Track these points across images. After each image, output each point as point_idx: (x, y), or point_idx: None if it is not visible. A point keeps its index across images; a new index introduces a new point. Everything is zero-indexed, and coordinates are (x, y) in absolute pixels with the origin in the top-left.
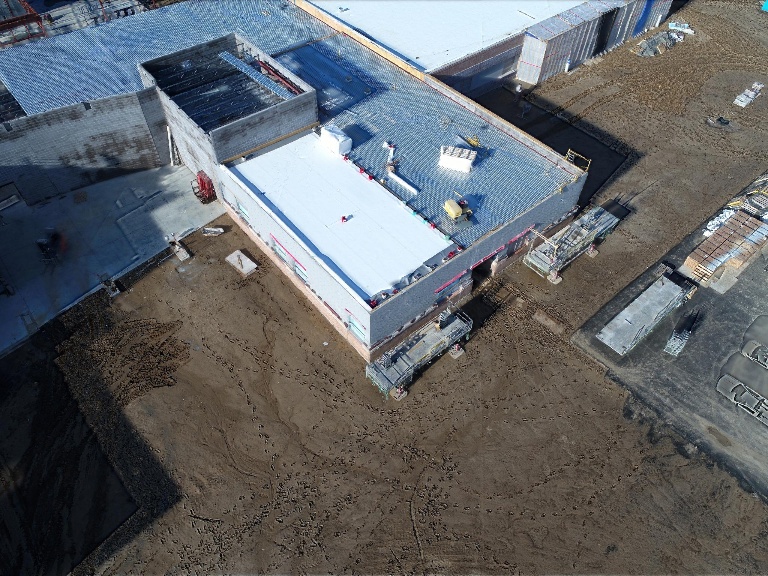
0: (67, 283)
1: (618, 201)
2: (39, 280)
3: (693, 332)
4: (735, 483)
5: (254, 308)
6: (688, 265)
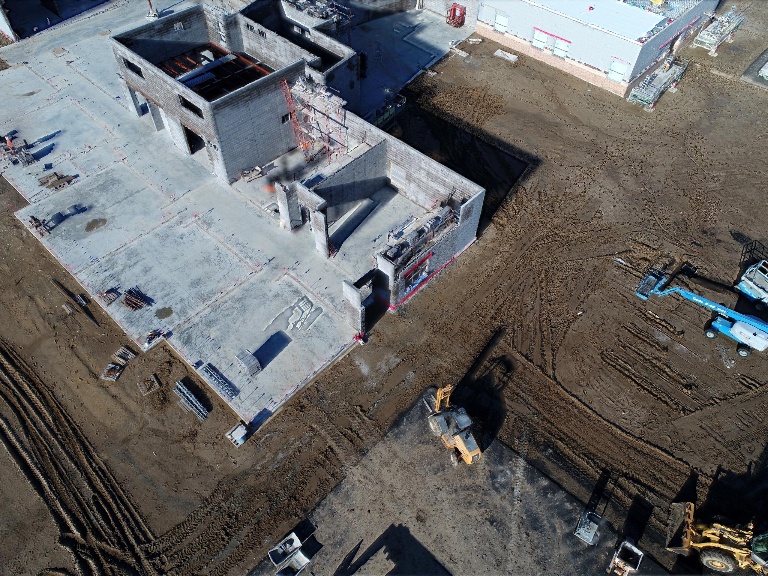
0: (398, 70)
1: None
2: (377, 70)
3: None
4: None
5: (531, 77)
6: None
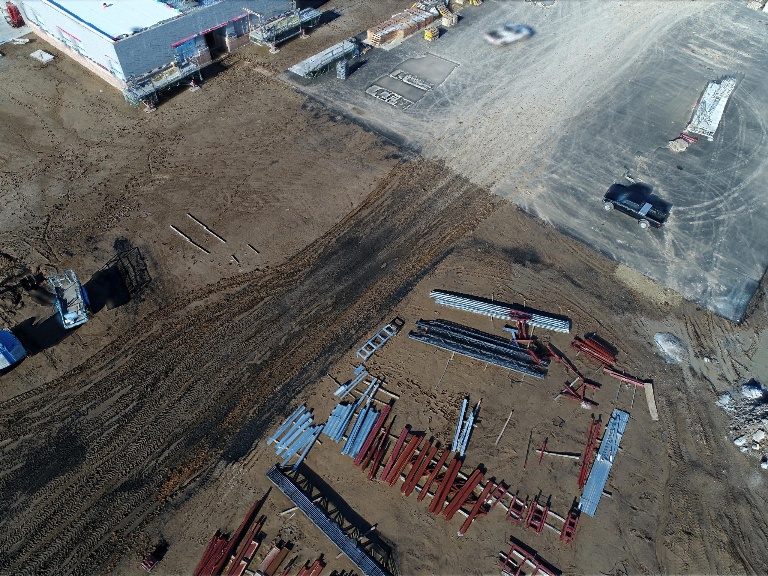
0: None
1: (333, 11)
2: None
3: (361, 68)
4: (361, 129)
5: (50, 78)
6: (369, 38)
